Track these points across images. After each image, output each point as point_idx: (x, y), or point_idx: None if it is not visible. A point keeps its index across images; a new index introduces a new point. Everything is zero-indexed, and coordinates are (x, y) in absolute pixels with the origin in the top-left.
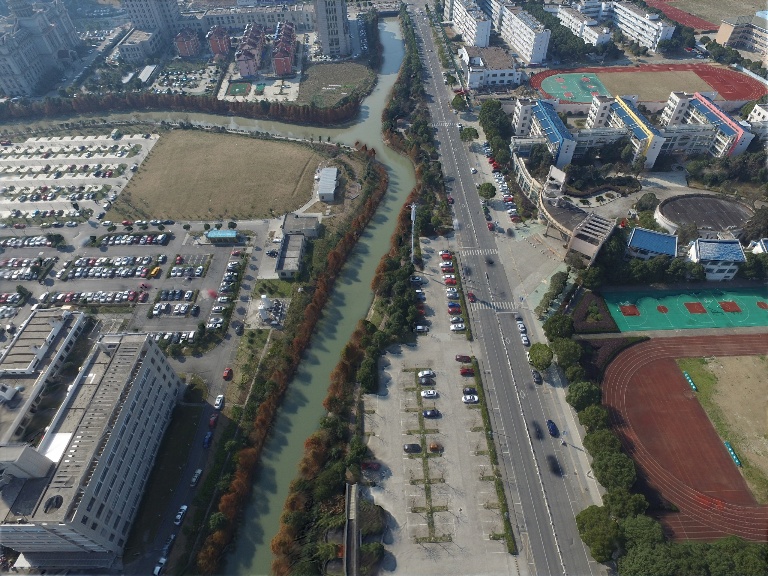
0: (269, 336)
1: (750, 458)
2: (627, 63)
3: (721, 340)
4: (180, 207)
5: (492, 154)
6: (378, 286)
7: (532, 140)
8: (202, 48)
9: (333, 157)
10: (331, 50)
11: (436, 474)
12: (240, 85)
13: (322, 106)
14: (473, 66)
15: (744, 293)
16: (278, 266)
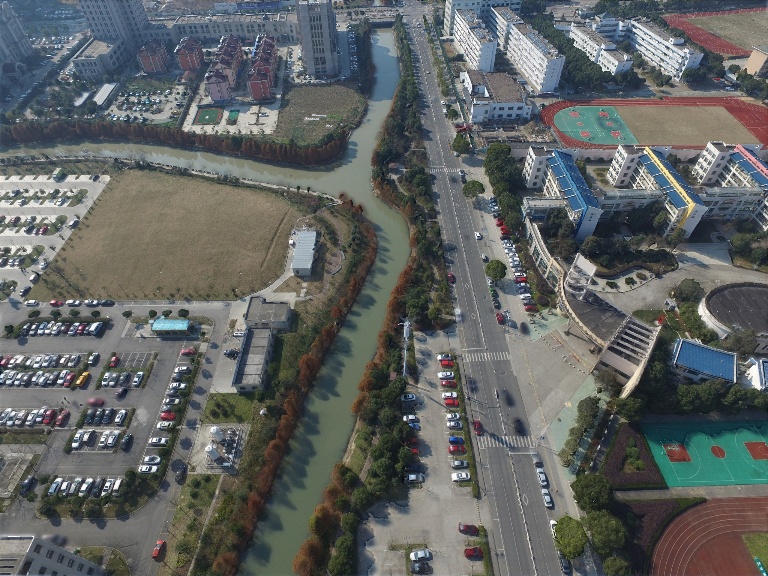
0: (219, 486)
1: None
2: (649, 94)
3: None
4: (124, 281)
5: (500, 215)
6: (361, 409)
7: (549, 202)
8: (171, 62)
9: (313, 213)
10: (316, 70)
11: None
12: (211, 111)
13: (303, 142)
14: (477, 97)
15: None
16: (236, 378)
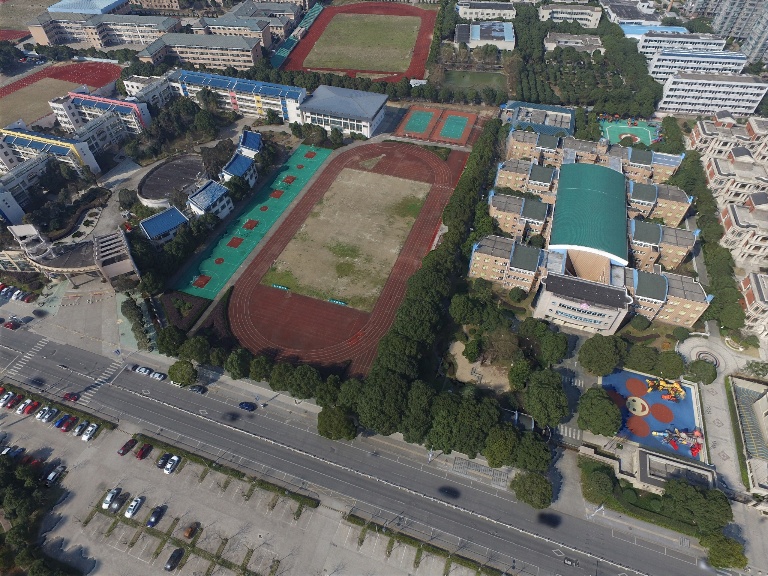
0: None
1: (345, 295)
2: None
3: (268, 248)
4: None
5: None
6: None
7: None
8: None
9: None
10: None
11: (215, 545)
12: None
13: None
14: None
15: (248, 210)
16: None
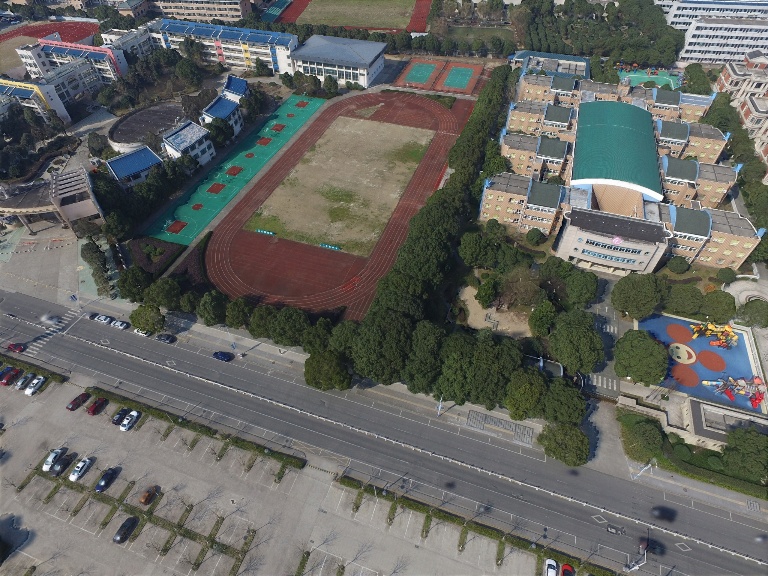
0: None
1: (339, 240)
2: None
3: (252, 193)
4: None
5: None
6: None
7: None
8: None
9: None
10: None
11: (177, 512)
12: None
13: None
14: None
15: (232, 157)
16: None
